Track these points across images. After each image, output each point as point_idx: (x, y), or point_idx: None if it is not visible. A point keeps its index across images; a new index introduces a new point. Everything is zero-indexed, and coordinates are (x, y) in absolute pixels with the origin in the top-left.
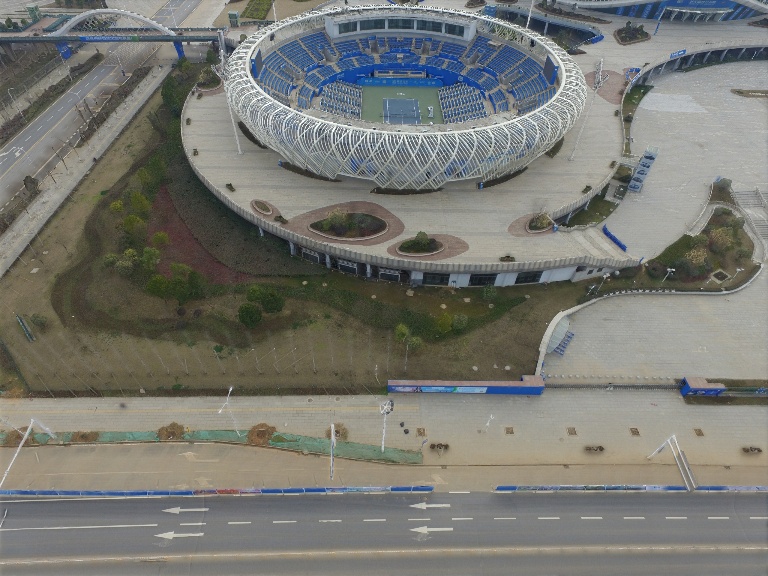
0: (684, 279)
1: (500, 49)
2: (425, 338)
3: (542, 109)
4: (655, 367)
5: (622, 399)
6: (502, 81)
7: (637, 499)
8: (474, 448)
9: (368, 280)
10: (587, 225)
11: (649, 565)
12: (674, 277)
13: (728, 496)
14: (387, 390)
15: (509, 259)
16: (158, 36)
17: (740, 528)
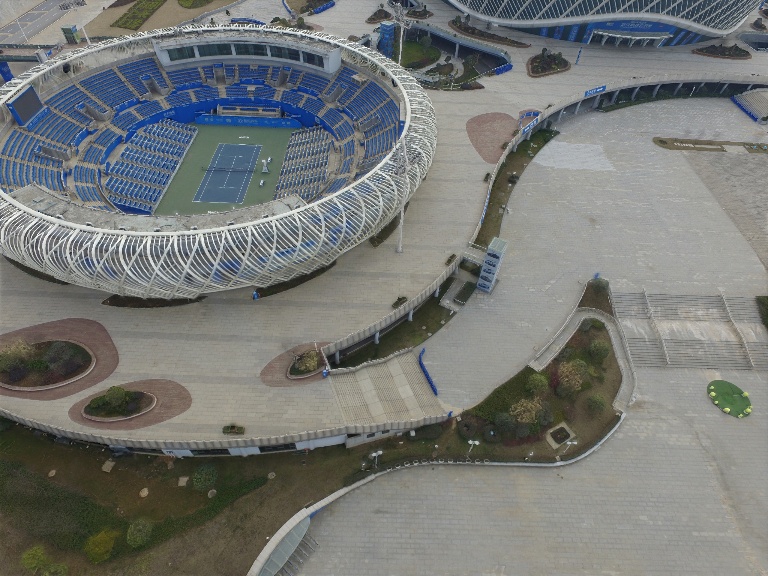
0: (507, 442)
1: (365, 86)
2: (88, 557)
3: (344, 192)
4: None
5: None
6: (359, 128)
7: None
8: None
9: (59, 442)
10: (390, 355)
11: None
12: (492, 440)
13: None
14: None
15: (234, 431)
16: None
17: None
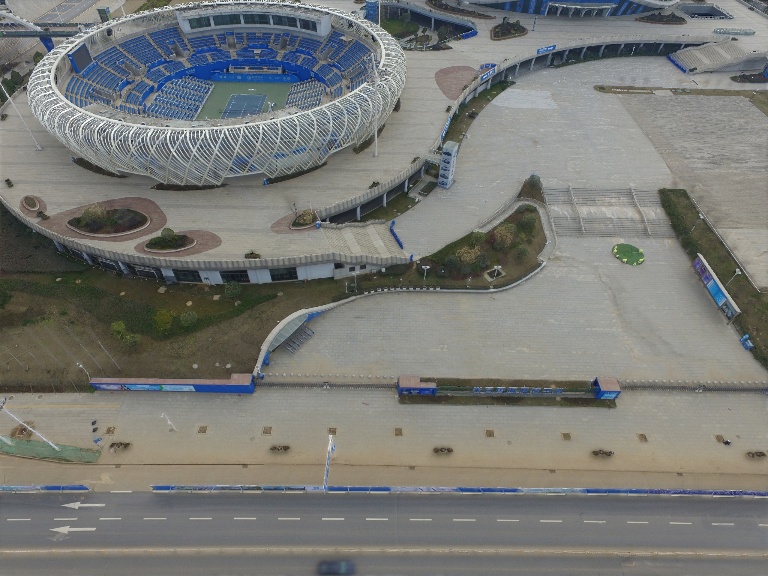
0: (454, 277)
1: (351, 44)
2: (153, 335)
3: (331, 104)
4: (385, 366)
5: (335, 398)
6: (346, 77)
7: (297, 500)
8: (157, 447)
9: (125, 277)
10: (367, 222)
11: (280, 567)
12: (442, 275)
13: (390, 497)
14: (94, 388)
15: (253, 256)
16: (21, 32)
17: (394, 530)
